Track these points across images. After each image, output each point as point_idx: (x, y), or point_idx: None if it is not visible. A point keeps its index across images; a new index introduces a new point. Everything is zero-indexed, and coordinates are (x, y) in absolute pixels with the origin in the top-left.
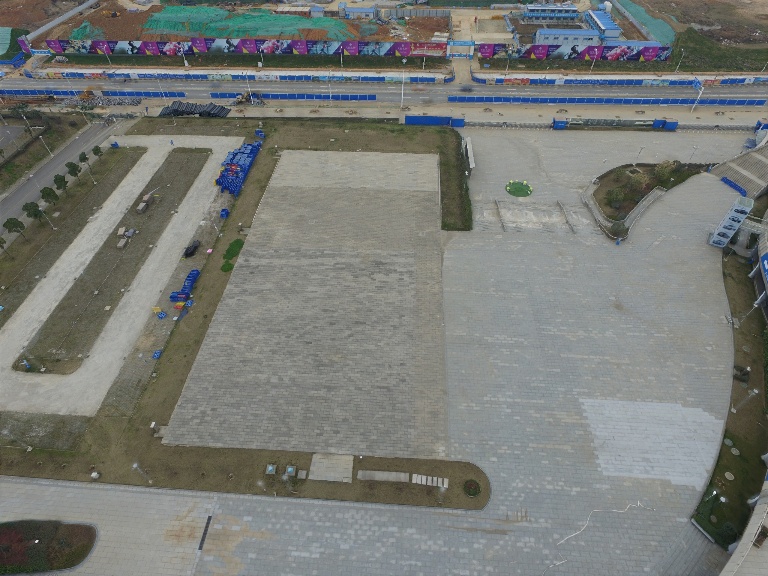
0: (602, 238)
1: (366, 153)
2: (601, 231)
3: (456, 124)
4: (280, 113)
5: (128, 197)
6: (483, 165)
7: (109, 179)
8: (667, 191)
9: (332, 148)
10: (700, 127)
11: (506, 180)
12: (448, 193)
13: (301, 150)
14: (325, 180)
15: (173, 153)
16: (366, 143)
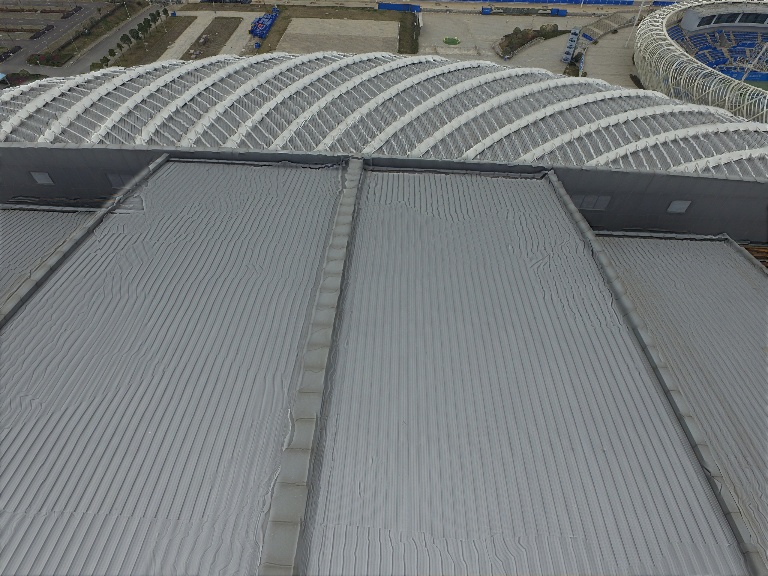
0: (497, 58)
1: (350, 20)
2: (497, 56)
3: (414, 10)
4: (288, 3)
5: (191, 38)
6: (430, 30)
7: (175, 30)
8: (545, 40)
9: (327, 17)
10: (582, 14)
11: (444, 37)
12: (404, 39)
13: (305, 18)
14: (323, 31)
15: (216, 19)
16: (350, 15)
